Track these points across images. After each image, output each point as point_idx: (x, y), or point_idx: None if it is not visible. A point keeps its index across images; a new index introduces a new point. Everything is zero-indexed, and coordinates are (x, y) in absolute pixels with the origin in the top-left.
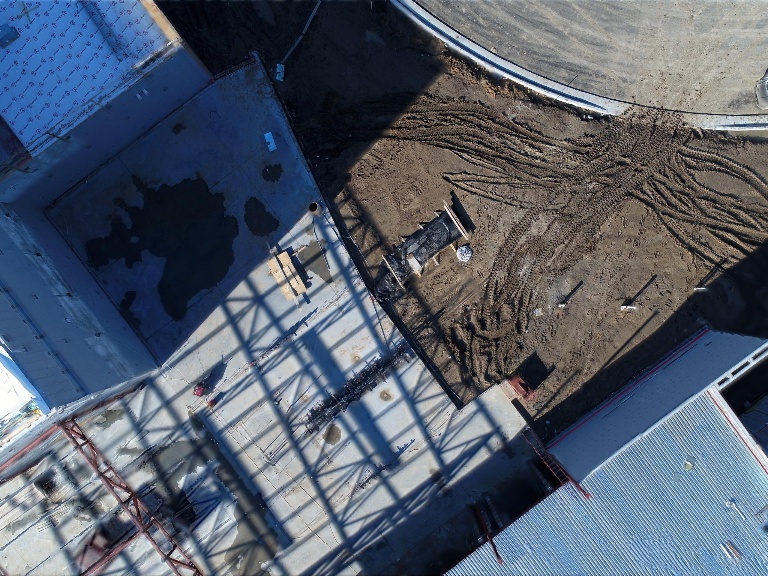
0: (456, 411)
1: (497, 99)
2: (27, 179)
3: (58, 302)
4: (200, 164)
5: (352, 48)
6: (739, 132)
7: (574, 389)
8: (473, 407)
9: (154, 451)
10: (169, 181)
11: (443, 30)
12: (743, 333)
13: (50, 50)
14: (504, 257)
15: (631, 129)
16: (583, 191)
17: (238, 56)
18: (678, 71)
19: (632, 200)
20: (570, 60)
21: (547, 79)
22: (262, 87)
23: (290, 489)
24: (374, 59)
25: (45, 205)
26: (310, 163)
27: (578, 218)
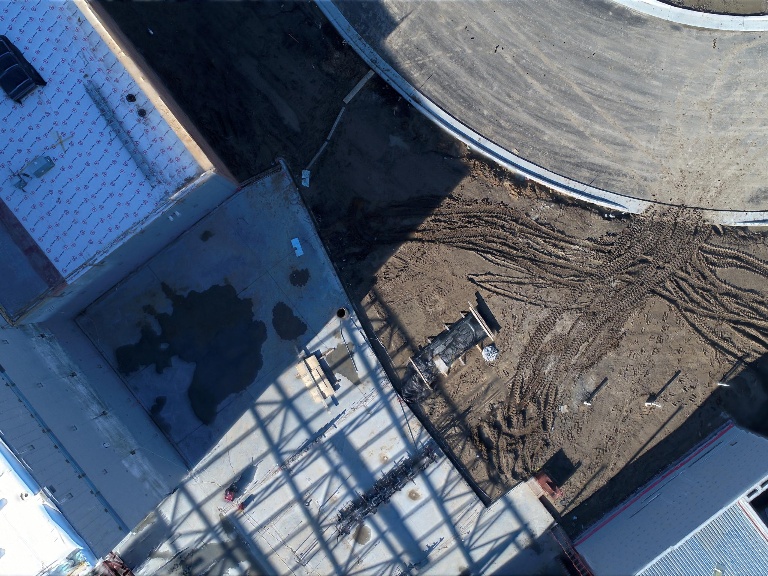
0: (484, 509)
1: (520, 200)
2: (62, 300)
3: (95, 425)
4: (228, 270)
5: (376, 153)
6: (759, 227)
7: (600, 485)
8: (501, 505)
9: (186, 553)
10: (198, 287)
11: (465, 133)
12: (767, 427)
13: (84, 178)
14: (529, 356)
15: (652, 227)
16: (606, 289)
17: (264, 163)
18: (698, 169)
19: (655, 297)
20: (591, 160)
21: (569, 179)
22: (288, 194)
23: None
24: (398, 163)
25: (76, 313)
26: (336, 267)
27: (602, 316)
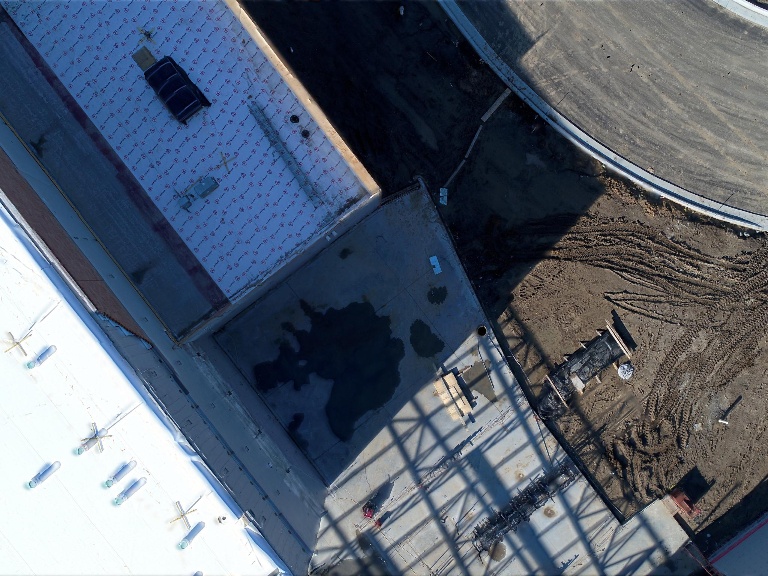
0: (619, 526)
1: (655, 219)
2: (218, 319)
3: (257, 445)
4: (366, 288)
5: (513, 171)
6: None
7: (734, 502)
8: (636, 522)
9: (322, 570)
10: (336, 305)
11: (601, 151)
12: None
13: (248, 199)
14: (664, 374)
15: None
16: (741, 308)
17: (402, 181)
18: None
19: None
20: (726, 179)
21: (704, 198)
22: (427, 212)
23: None
24: (535, 181)
25: None
26: (473, 284)
27: (737, 334)
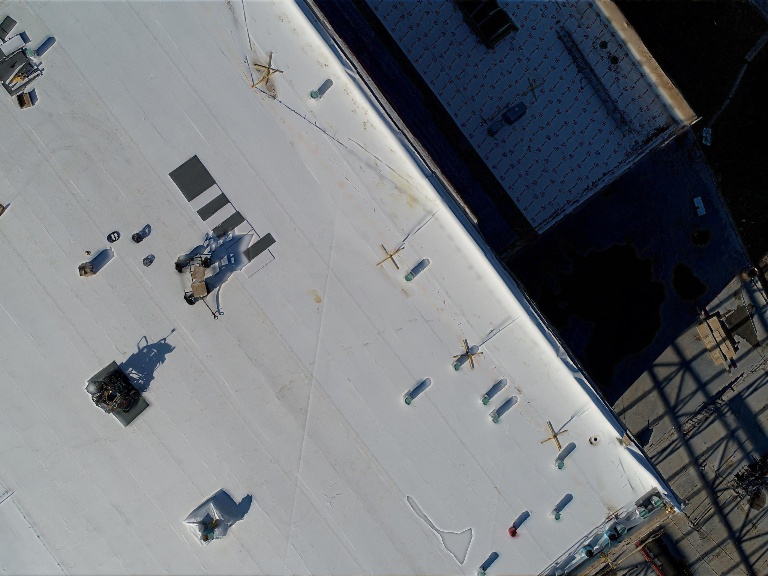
0: None
1: None
2: None
3: None
4: (629, 229)
5: None
6: None
7: None
8: None
9: None
10: (598, 246)
11: None
12: None
13: (555, 126)
14: None
15: None
16: None
17: None
18: None
19: None
20: None
21: None
22: (691, 152)
23: (714, 555)
24: None
25: None
26: (736, 227)
27: None
